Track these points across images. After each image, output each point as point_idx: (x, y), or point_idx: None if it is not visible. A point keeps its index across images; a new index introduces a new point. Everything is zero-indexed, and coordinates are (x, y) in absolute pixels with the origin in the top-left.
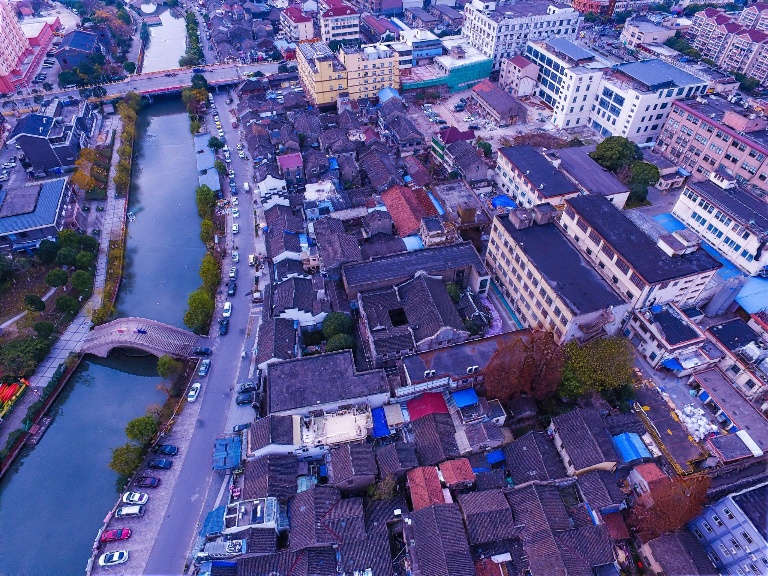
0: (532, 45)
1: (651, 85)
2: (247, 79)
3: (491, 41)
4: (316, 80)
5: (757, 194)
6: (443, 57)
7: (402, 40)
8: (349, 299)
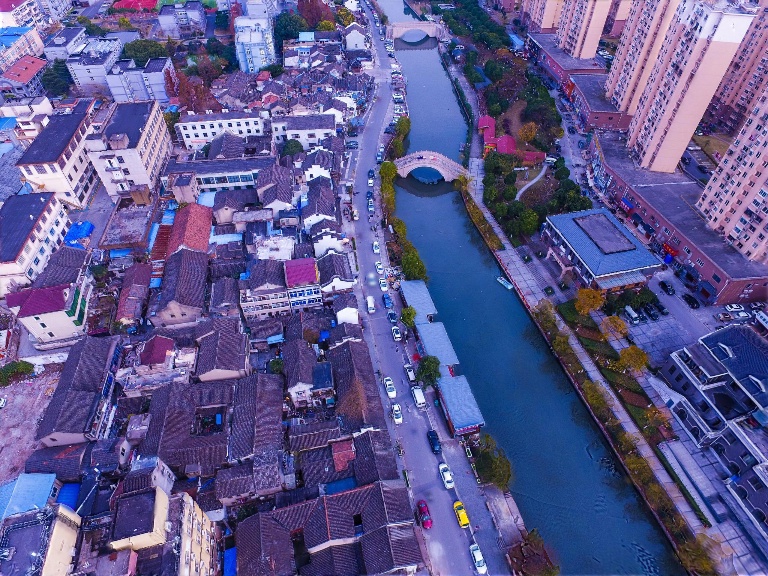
0: None
1: None
2: None
3: None
4: None
5: None
6: None
7: None
8: None
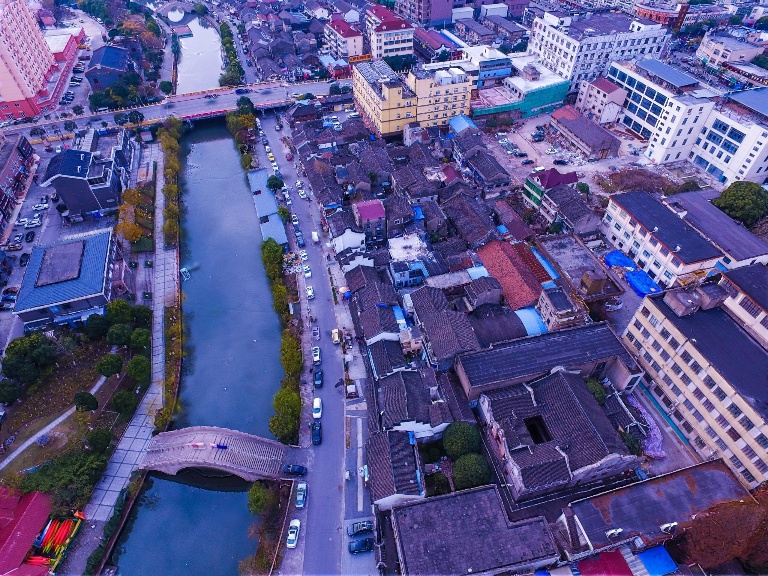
0: (617, 66)
1: None
2: (299, 103)
3: (569, 61)
4: (383, 108)
5: None
6: (514, 78)
7: (466, 58)
8: (469, 399)
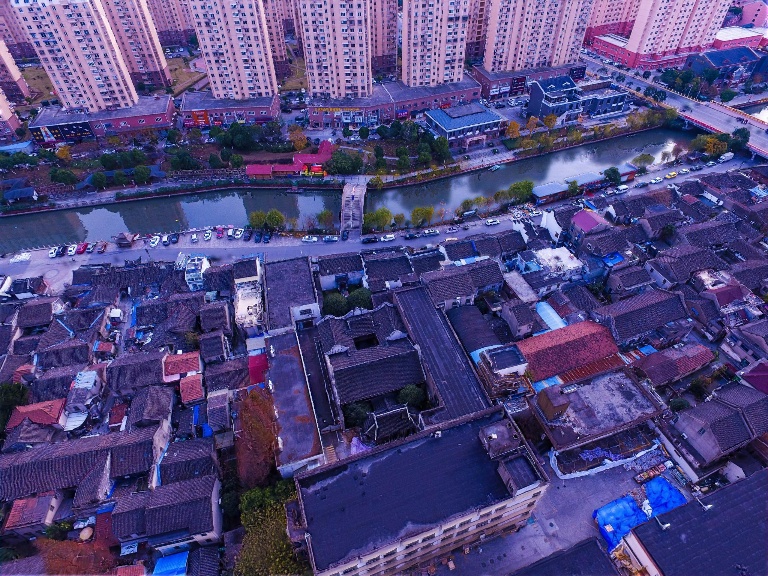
0: None
1: None
2: None
3: None
4: None
5: None
6: None
7: None
8: None
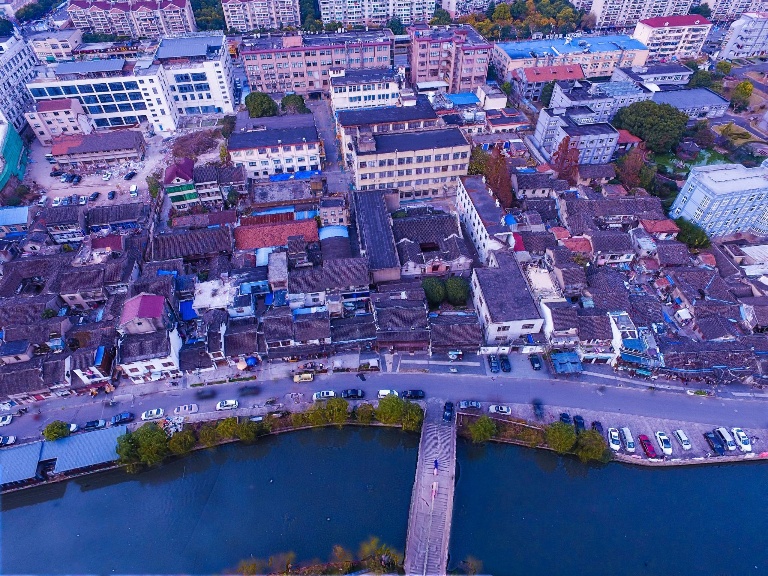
0: (38, 86)
1: (205, 54)
2: None
3: None
4: None
5: (354, 69)
6: None
7: None
8: None
